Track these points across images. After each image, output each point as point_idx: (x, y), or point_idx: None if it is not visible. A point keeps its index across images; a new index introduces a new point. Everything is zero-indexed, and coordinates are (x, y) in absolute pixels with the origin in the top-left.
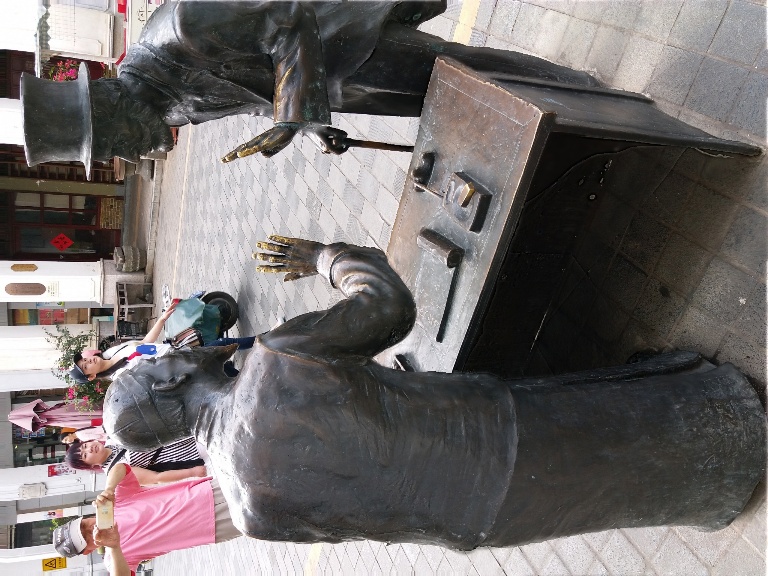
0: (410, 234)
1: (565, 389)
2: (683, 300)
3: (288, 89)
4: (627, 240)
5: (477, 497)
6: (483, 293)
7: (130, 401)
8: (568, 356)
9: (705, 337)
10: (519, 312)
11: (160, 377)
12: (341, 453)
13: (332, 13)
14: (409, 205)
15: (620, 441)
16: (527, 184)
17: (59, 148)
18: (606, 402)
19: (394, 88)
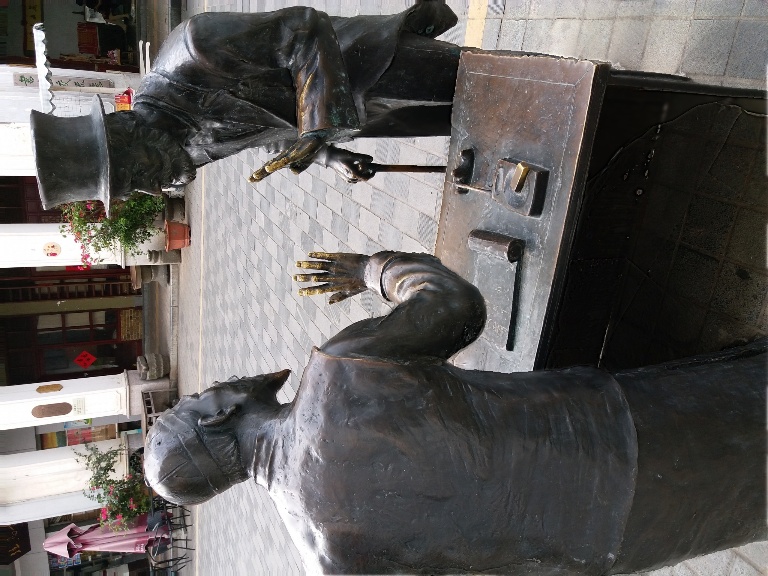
0: (457, 243)
1: (673, 372)
2: (767, 278)
3: (311, 96)
4: (687, 228)
5: (599, 508)
6: (555, 282)
7: (174, 442)
8: None
9: None
10: (579, 328)
11: (206, 411)
12: (431, 468)
13: (345, 27)
14: (451, 213)
15: (749, 426)
16: (589, 148)
17: (75, 183)
18: (722, 383)
19: (418, 97)
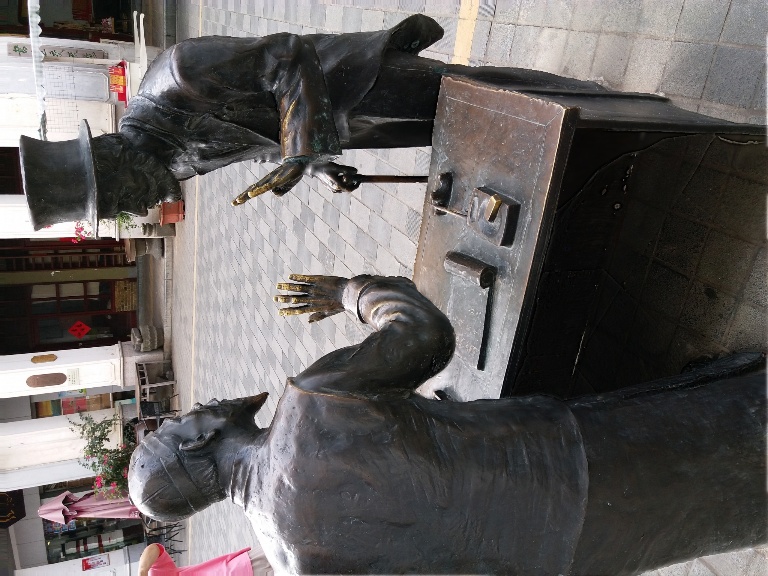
0: (435, 261)
1: (629, 403)
2: (733, 299)
3: (294, 122)
4: (661, 245)
5: (550, 533)
6: (523, 310)
7: (157, 465)
8: (614, 376)
9: (764, 336)
10: (556, 335)
11: (187, 436)
12: (394, 498)
13: (330, 46)
14: (430, 231)
15: (698, 454)
16: (557, 187)
17: (63, 207)
18: (675, 413)
19: (401, 115)
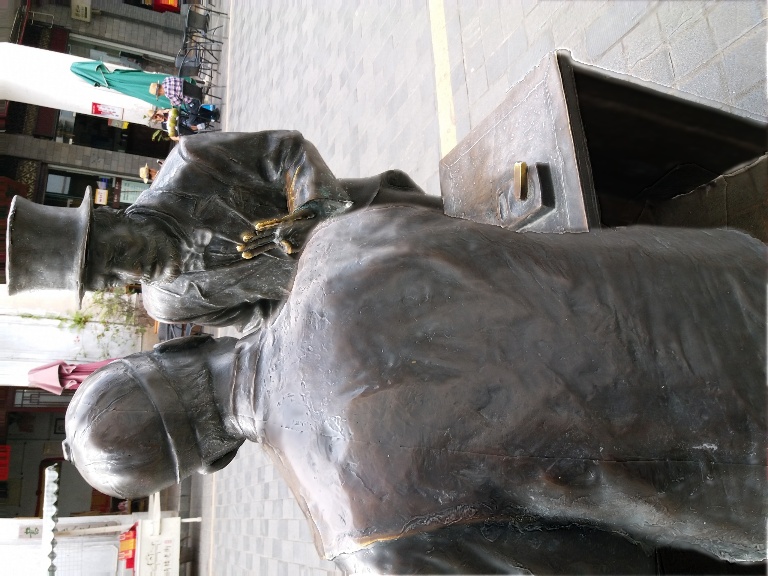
0: None
1: None
2: None
3: (300, 181)
4: None
5: (762, 333)
6: None
7: (118, 377)
8: None
9: None
10: None
11: None
12: (487, 288)
13: None
14: None
15: None
16: (577, 117)
17: (49, 252)
18: None
19: None
